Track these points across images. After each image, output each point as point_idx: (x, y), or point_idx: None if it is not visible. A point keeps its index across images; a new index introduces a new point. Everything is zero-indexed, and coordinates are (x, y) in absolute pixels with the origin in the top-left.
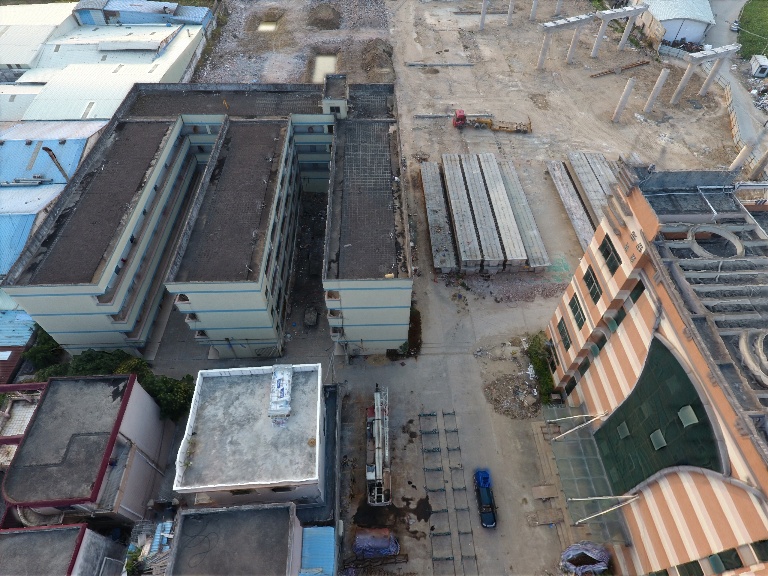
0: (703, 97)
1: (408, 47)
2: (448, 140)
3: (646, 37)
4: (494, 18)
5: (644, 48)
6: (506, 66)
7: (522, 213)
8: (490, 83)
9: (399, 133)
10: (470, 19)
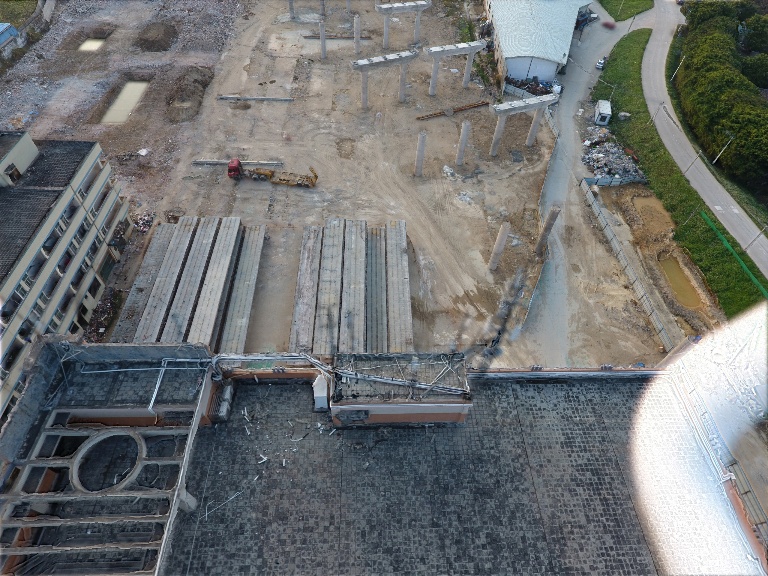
0: (529, 148)
1: (232, 76)
2: (216, 194)
3: (497, 73)
4: (345, 44)
5: (492, 86)
6: (329, 103)
7: (242, 294)
8: (301, 123)
9: (50, 210)
10: (318, 44)
